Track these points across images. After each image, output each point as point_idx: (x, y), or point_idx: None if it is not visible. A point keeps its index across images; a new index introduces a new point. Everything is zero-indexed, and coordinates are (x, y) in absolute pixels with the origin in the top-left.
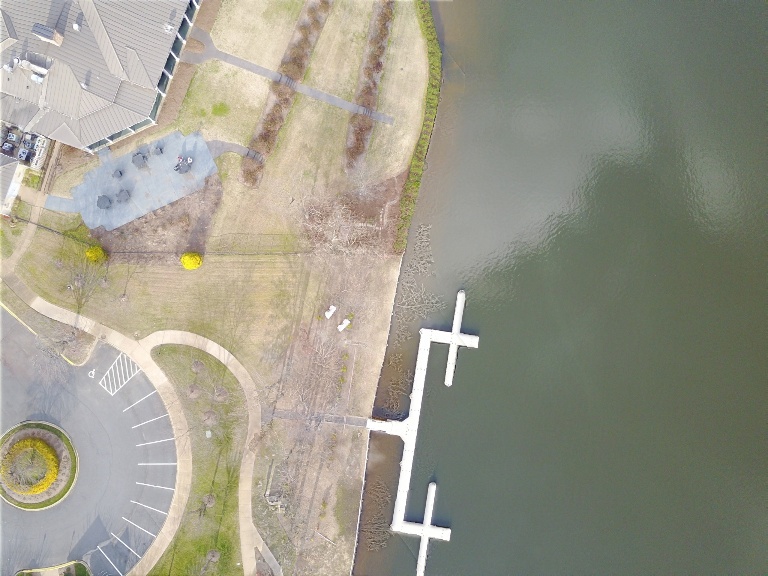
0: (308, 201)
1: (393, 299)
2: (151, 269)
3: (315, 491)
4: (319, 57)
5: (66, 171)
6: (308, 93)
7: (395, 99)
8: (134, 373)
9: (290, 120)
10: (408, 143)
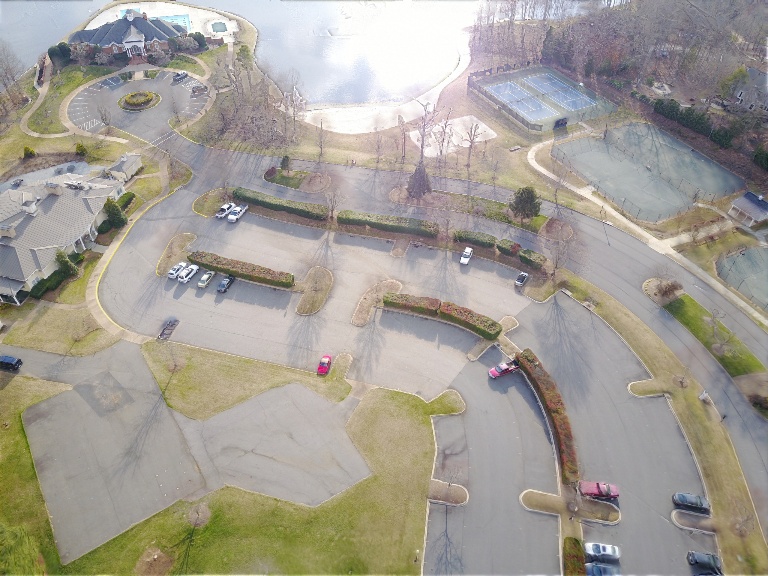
0: None
1: None
2: None
3: (7, 105)
4: None
5: None
6: None
7: None
8: None
9: None
10: None
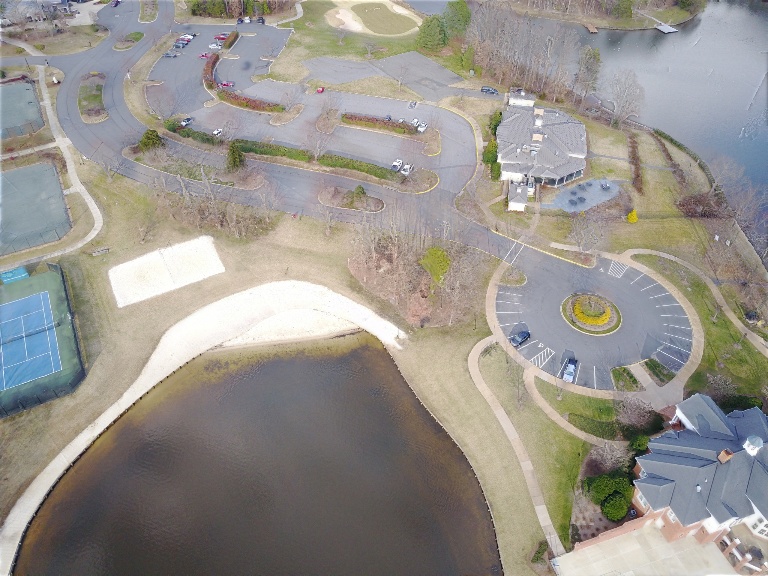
0: (673, 199)
1: (744, 235)
2: (611, 225)
3: None
4: (643, 156)
5: (545, 195)
6: (646, 166)
7: (687, 169)
8: (626, 268)
9: (644, 175)
10: (704, 182)
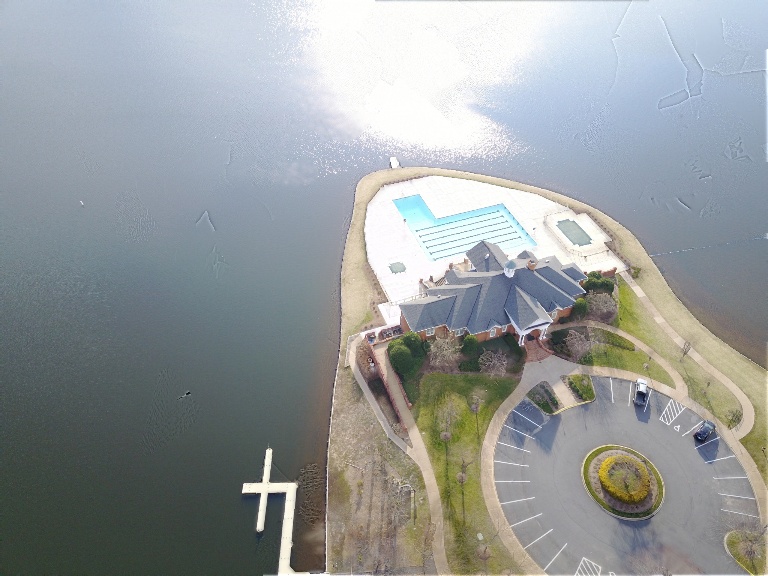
0: None
1: None
2: None
3: (370, 503)
4: None
5: None
6: None
7: None
8: None
9: None
10: None
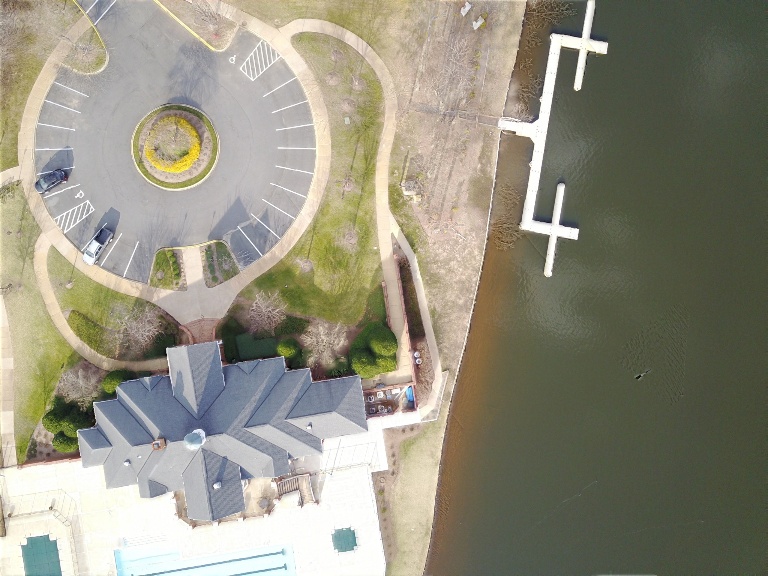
0: None
1: (525, 3)
2: None
3: (448, 185)
4: None
5: None
6: None
7: None
8: (274, 60)
9: None
10: None
